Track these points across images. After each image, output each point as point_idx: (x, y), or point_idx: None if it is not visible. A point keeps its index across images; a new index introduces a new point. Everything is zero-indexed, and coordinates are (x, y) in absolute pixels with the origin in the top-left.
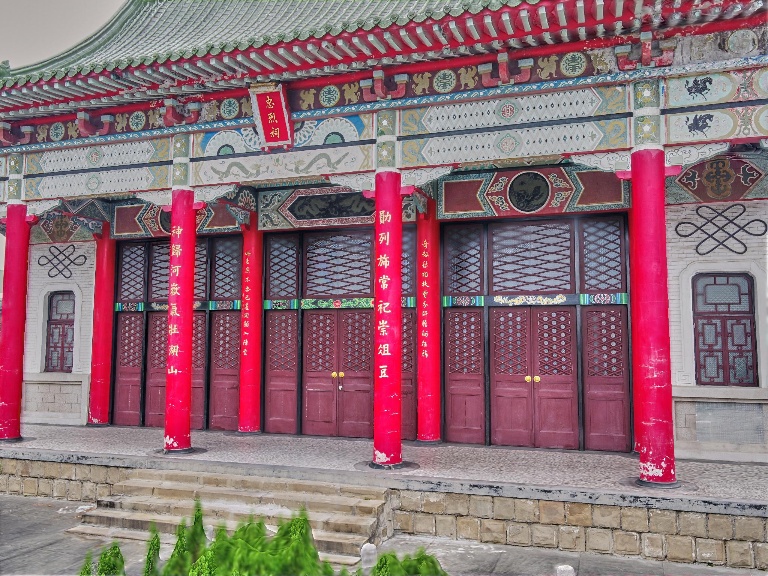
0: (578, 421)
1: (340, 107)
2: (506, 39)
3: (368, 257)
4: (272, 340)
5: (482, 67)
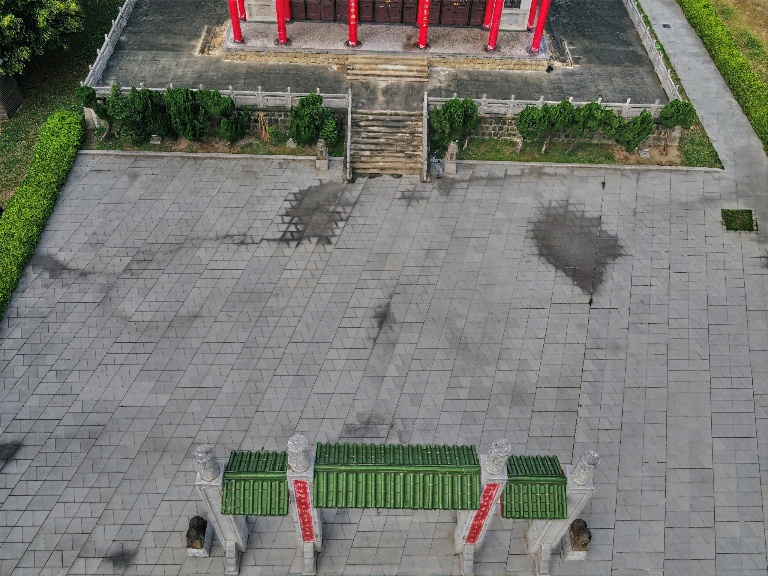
0: (468, 17)
1: None
2: None
3: None
4: None
5: None
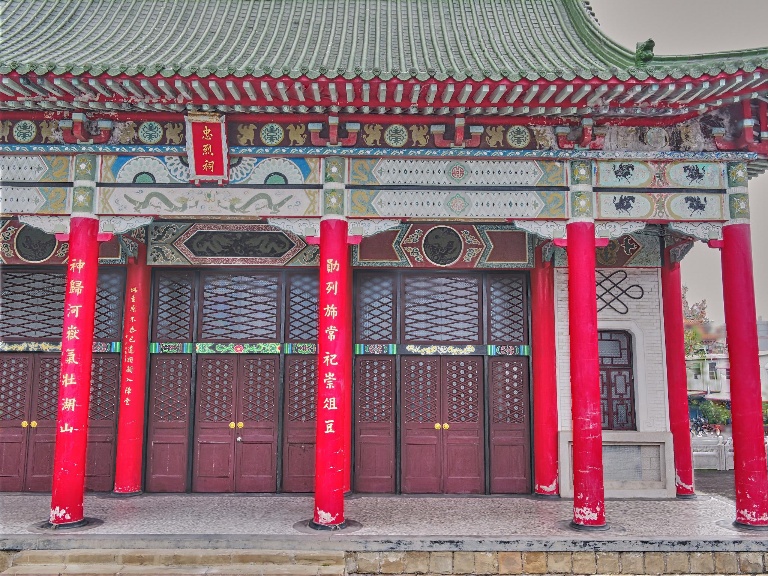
0: (484, 466)
1: (286, 148)
2: (473, 107)
3: (274, 300)
4: (158, 387)
5: (435, 127)
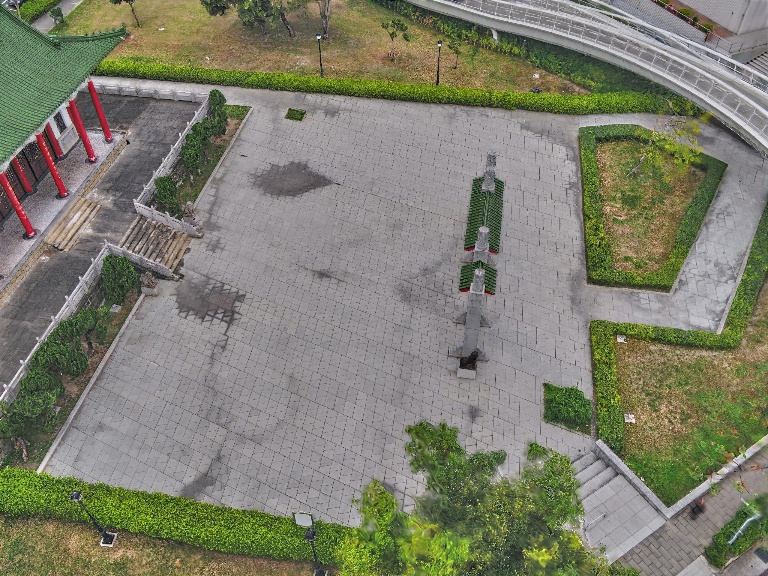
0: None
1: None
2: None
3: None
4: None
5: None
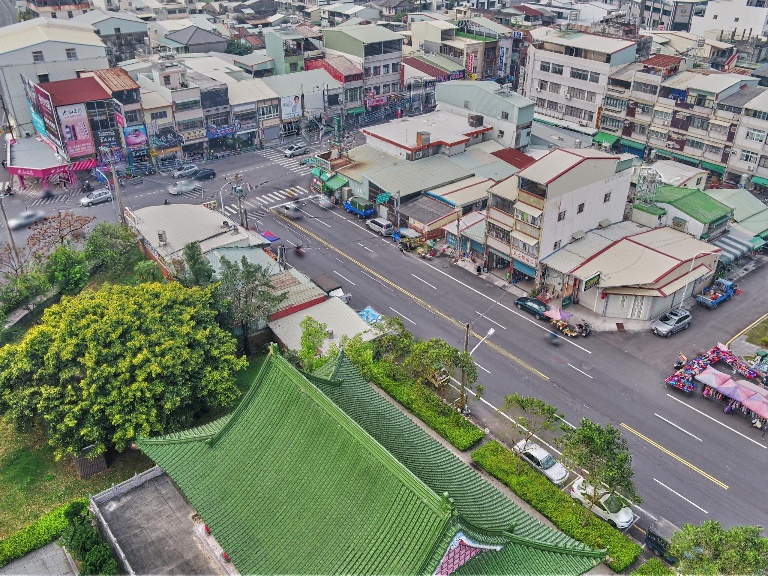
0: None
1: None
2: None
3: None
4: None
5: None
